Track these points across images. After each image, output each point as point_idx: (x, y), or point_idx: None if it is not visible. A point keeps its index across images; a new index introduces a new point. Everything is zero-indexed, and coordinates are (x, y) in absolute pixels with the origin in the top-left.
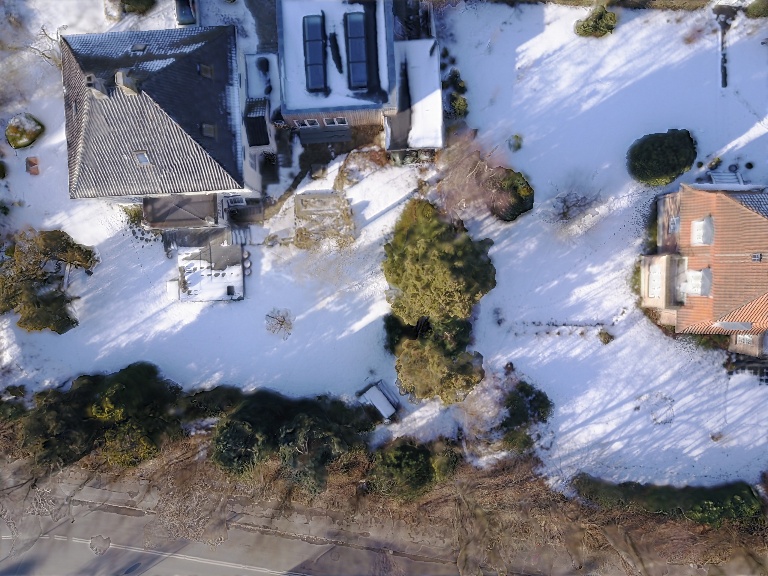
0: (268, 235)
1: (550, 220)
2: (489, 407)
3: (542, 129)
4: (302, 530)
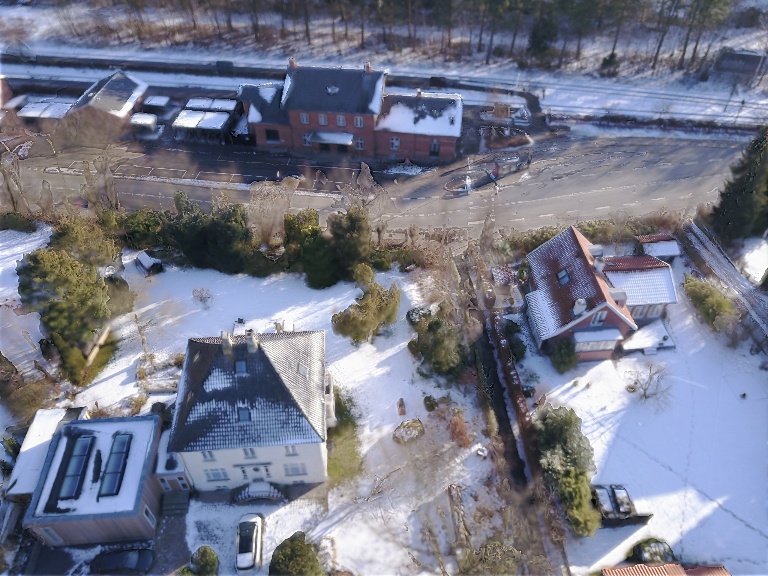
0: None
1: None
2: None
3: None
4: None
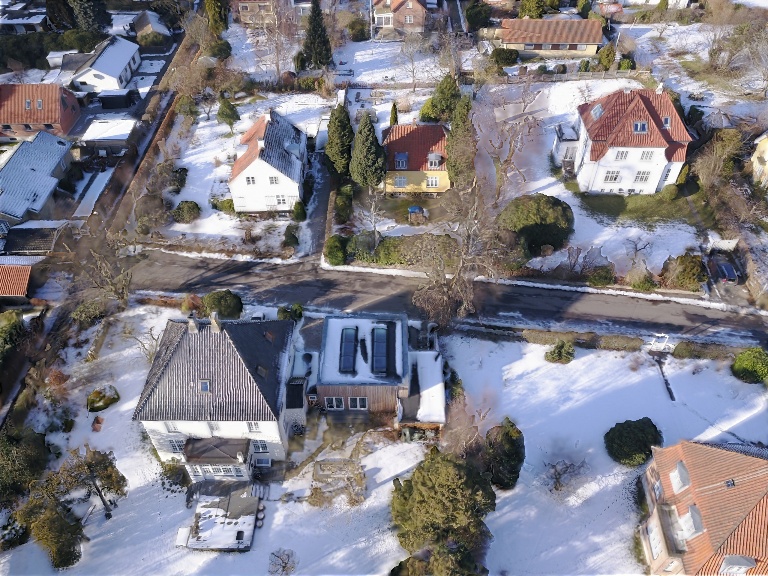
0: (285, 493)
1: (544, 482)
2: None
3: (529, 421)
4: None
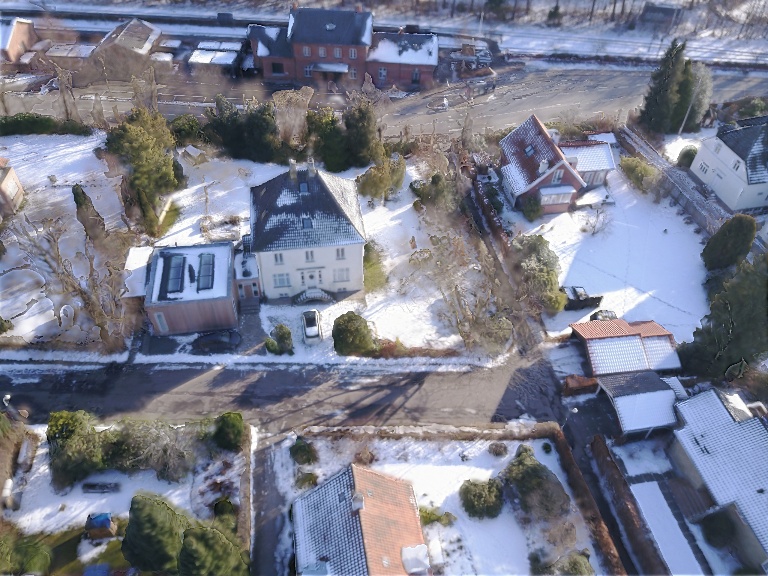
0: None
1: None
2: None
3: None
4: None
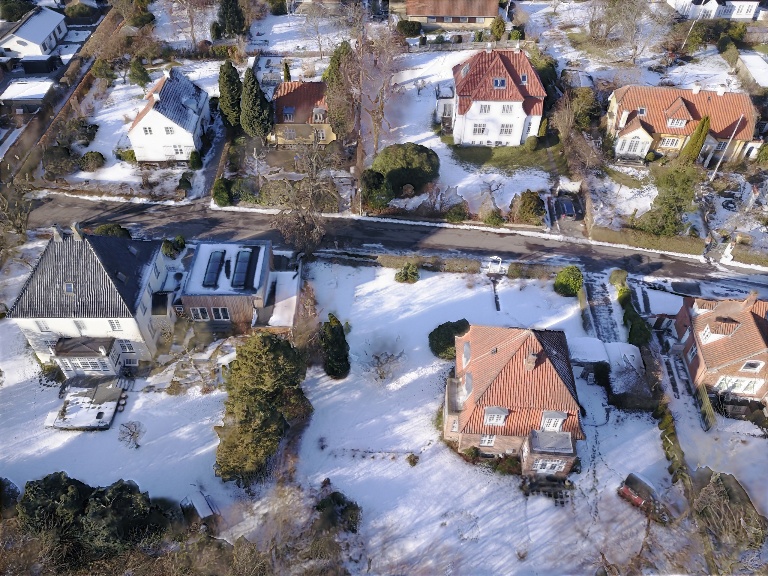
0: (147, 385)
1: (366, 369)
2: (302, 512)
3: (370, 327)
4: None
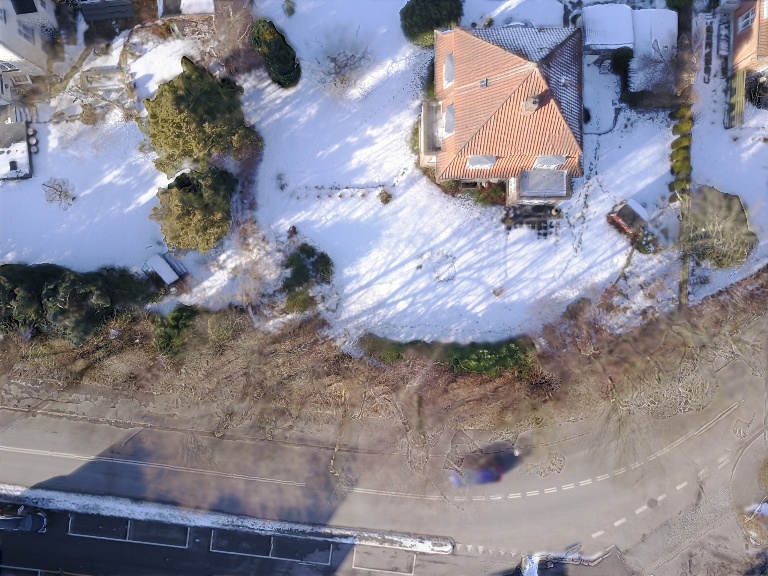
0: (54, 113)
1: (321, 80)
2: (271, 270)
3: None
4: (109, 414)
